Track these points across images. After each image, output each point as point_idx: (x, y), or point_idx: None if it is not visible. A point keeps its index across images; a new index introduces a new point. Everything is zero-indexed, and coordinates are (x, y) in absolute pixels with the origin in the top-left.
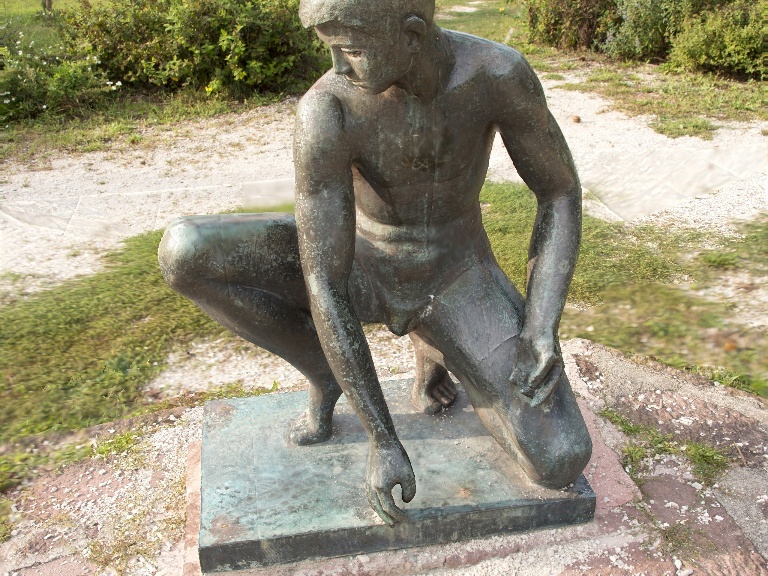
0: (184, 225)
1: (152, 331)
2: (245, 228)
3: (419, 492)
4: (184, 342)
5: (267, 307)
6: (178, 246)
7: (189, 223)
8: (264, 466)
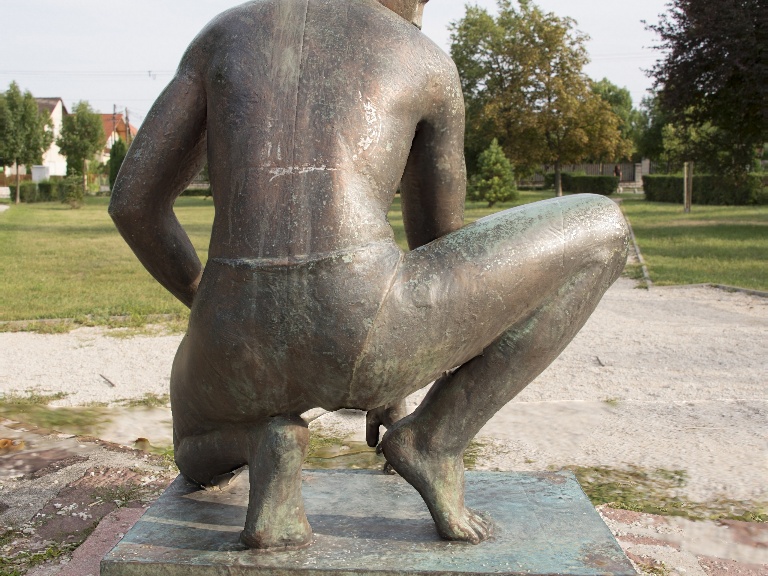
0: None
1: None
2: None
3: (352, 482)
4: None
5: None
6: None
7: None
8: (522, 510)
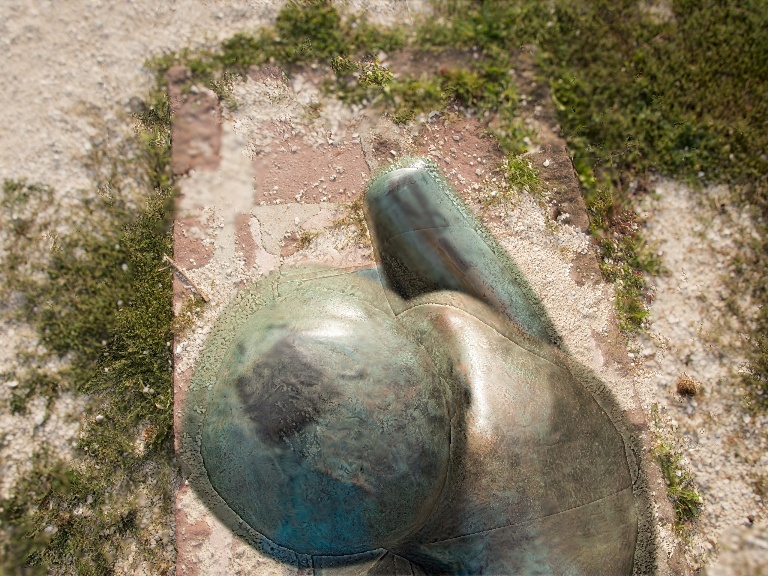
0: (390, 191)
1: (767, 154)
2: (418, 262)
3: None
4: (750, 195)
5: (395, 305)
6: (371, 193)
7: (394, 196)
8: None
